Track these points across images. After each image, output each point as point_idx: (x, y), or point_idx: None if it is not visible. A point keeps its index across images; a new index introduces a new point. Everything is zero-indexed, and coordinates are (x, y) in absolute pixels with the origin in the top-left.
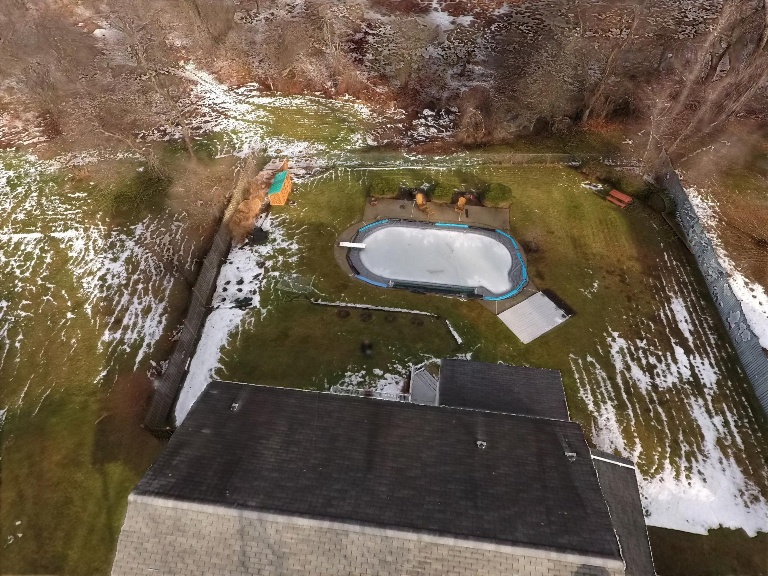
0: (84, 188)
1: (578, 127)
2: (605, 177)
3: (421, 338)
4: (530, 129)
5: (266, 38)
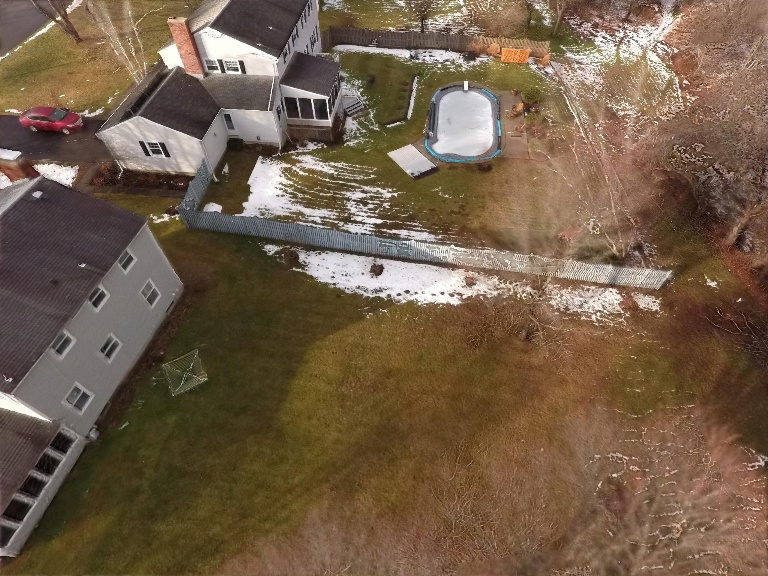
0: (506, 8)
1: (718, 239)
2: (608, 232)
3: (387, 108)
4: (653, 168)
5: (766, 46)
